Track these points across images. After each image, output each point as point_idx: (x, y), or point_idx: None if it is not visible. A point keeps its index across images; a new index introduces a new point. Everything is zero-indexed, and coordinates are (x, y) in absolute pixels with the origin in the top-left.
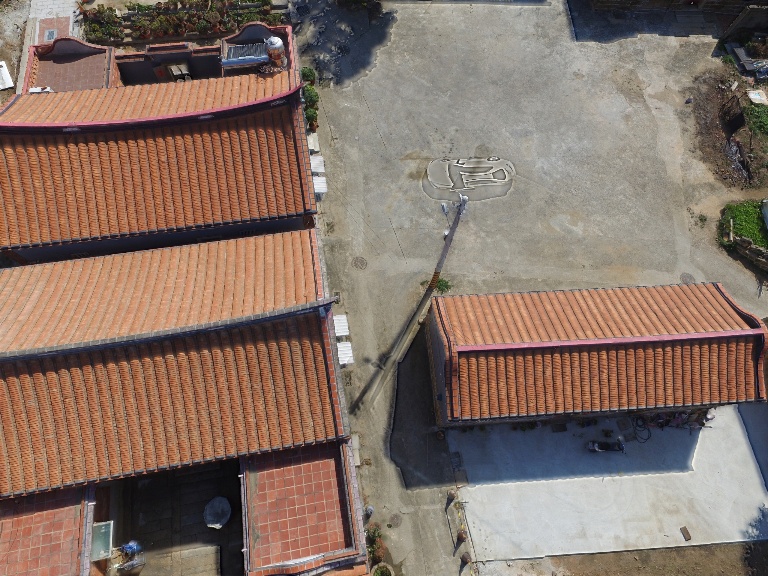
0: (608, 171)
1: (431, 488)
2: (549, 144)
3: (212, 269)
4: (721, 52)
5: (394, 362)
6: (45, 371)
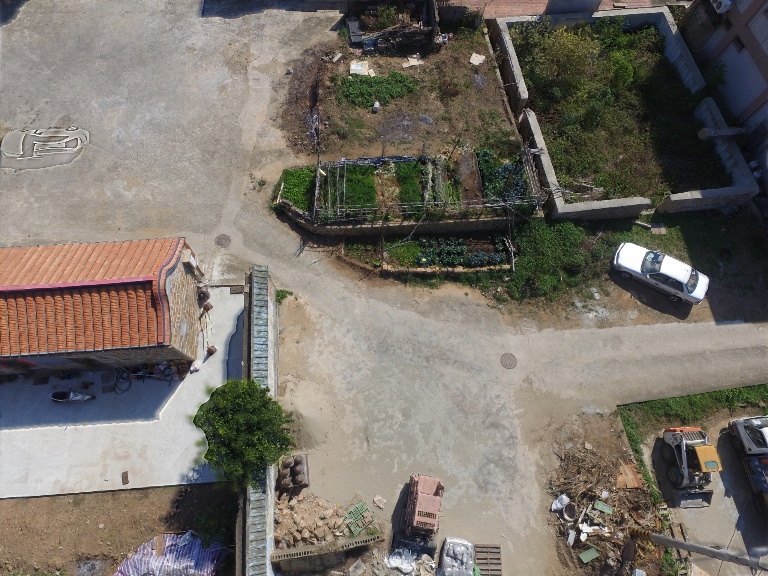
0: (183, 139)
1: None
2: (133, 114)
3: None
4: (341, 26)
5: None
6: None
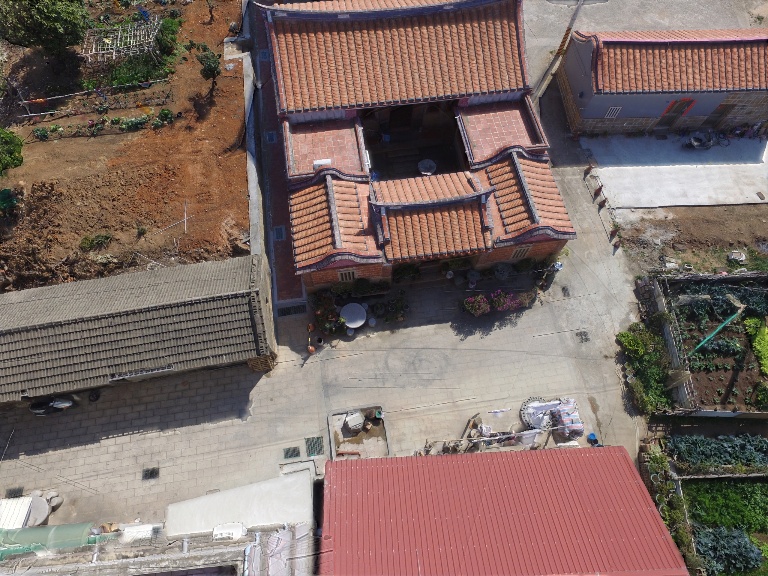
0: None
1: (572, 167)
2: None
3: (424, 2)
4: None
5: (536, 97)
6: (339, 32)
